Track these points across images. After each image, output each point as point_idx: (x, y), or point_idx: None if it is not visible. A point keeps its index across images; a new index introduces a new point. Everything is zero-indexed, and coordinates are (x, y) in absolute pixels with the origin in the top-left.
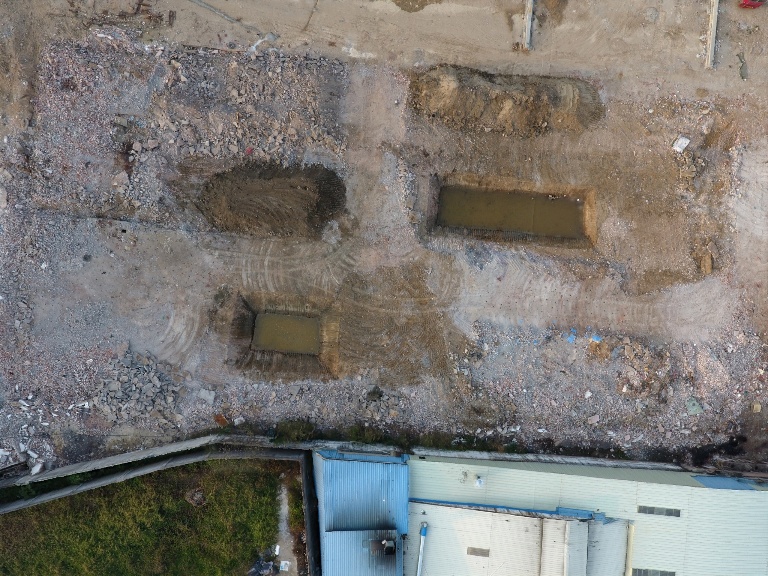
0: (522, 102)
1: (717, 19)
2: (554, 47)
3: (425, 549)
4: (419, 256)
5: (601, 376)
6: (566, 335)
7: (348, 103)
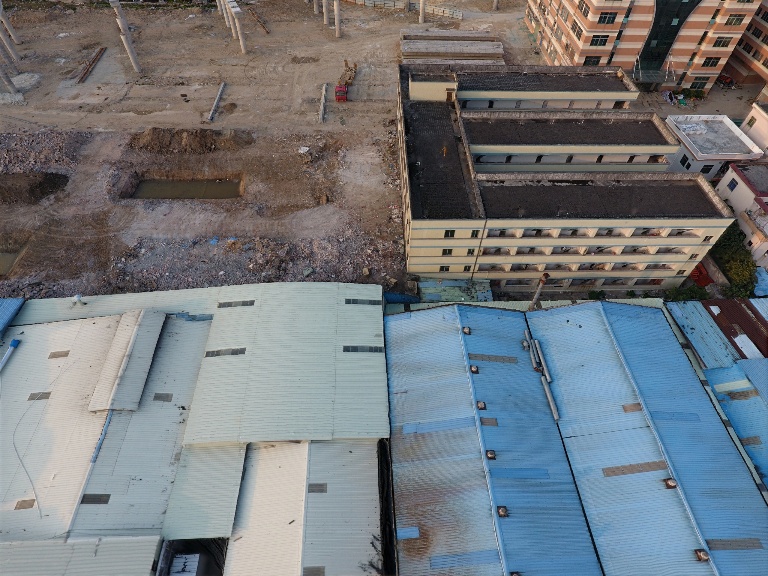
0: (193, 133)
1: (325, 107)
2: (226, 121)
3: (9, 362)
4: (108, 208)
5: (234, 261)
6: (210, 240)
7: (88, 147)
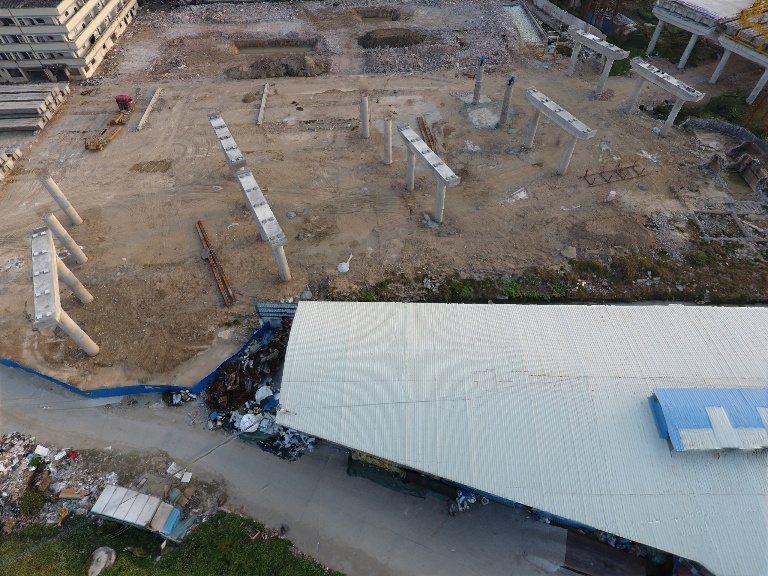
0: None
1: None
2: (251, 87)
3: None
4: (321, 32)
5: None
6: None
7: None
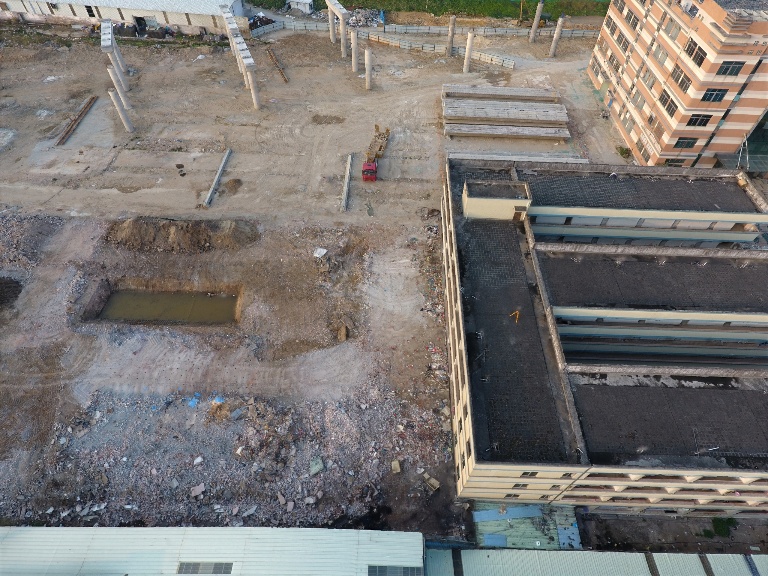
0: (183, 228)
1: (349, 188)
2: (227, 205)
3: None
4: (63, 338)
5: (218, 439)
6: (189, 400)
7: (54, 240)
